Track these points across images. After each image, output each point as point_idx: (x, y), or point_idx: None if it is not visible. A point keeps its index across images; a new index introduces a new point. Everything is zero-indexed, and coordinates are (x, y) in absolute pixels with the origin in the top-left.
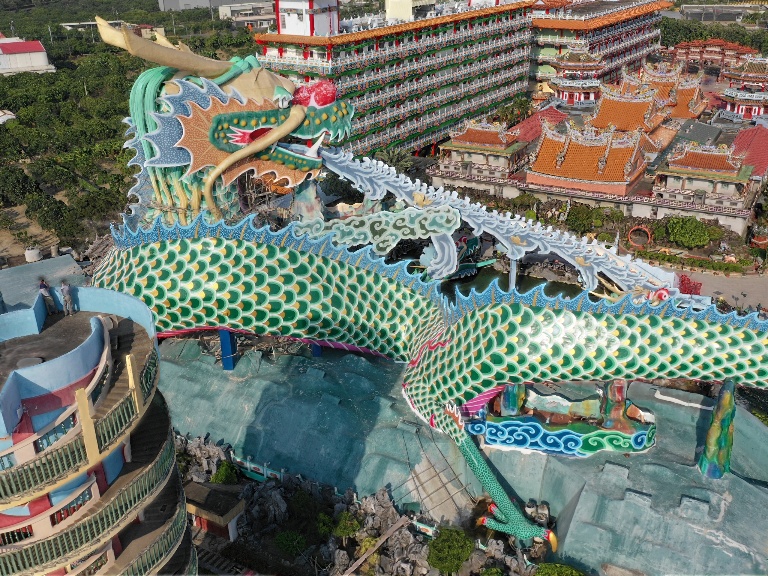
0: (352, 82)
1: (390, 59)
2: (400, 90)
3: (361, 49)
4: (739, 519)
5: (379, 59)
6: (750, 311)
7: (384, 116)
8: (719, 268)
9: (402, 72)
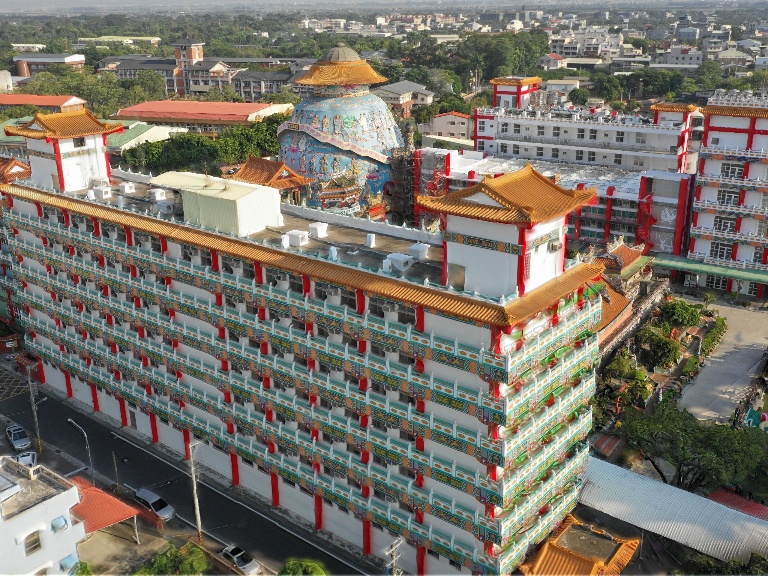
0: None
1: None
2: None
3: None
4: None
5: None
6: None
7: None
8: None
9: None
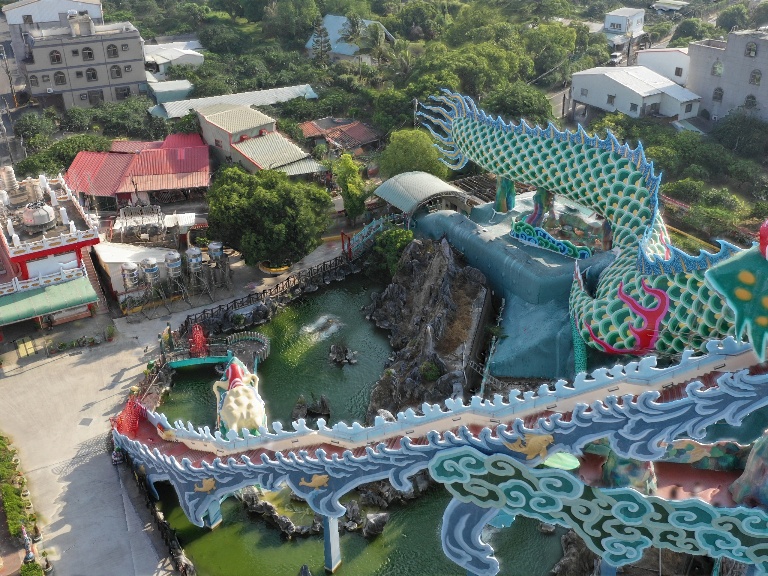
0: None
1: None
2: None
3: None
4: None
5: None
6: (119, 383)
7: None
8: (4, 446)
9: None
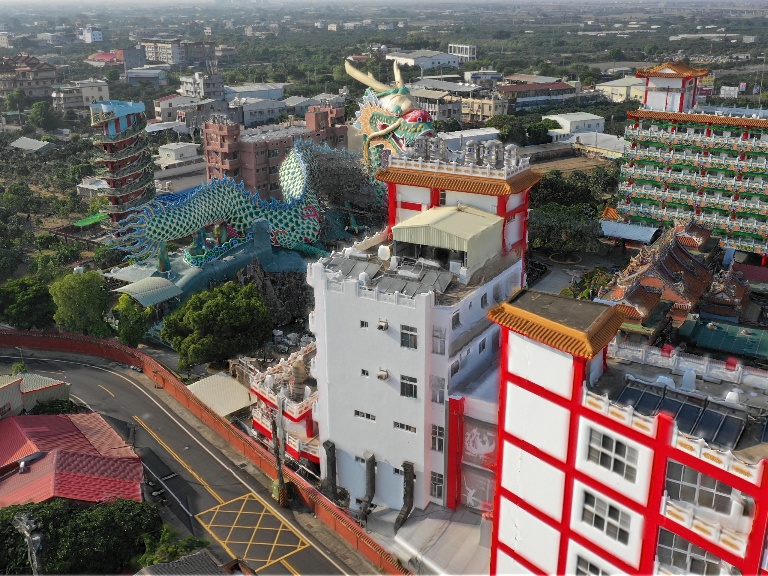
0: (653, 153)
1: (717, 147)
2: (731, 181)
3: (685, 129)
4: (133, 271)
5: (698, 143)
6: None
7: (698, 197)
8: None
9: (737, 165)
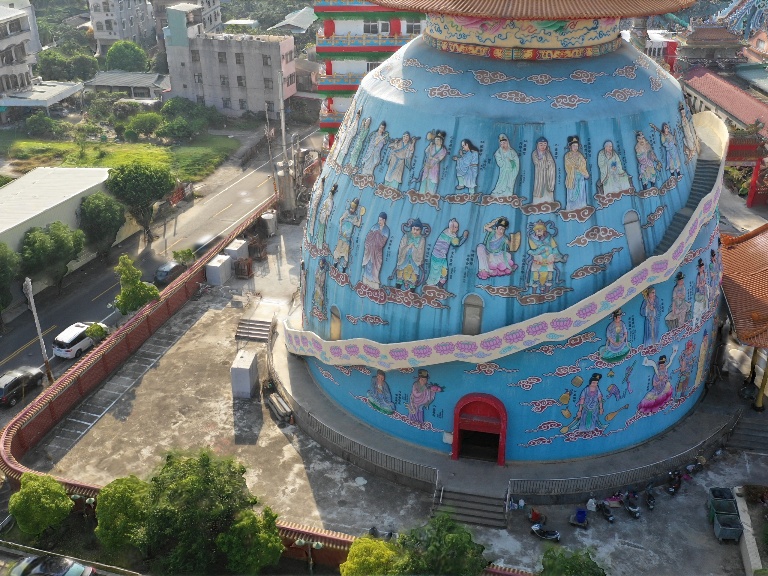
0: None
1: None
2: None
3: None
4: None
5: None
6: None
7: None
8: None
9: None
